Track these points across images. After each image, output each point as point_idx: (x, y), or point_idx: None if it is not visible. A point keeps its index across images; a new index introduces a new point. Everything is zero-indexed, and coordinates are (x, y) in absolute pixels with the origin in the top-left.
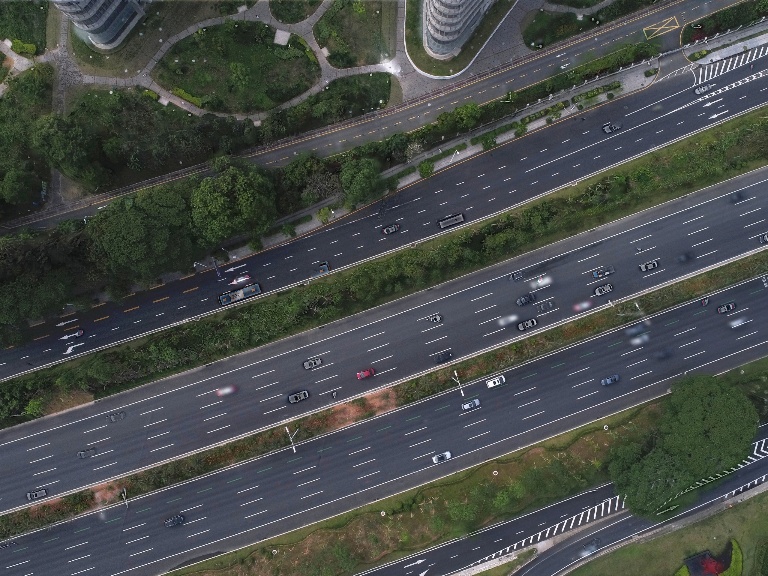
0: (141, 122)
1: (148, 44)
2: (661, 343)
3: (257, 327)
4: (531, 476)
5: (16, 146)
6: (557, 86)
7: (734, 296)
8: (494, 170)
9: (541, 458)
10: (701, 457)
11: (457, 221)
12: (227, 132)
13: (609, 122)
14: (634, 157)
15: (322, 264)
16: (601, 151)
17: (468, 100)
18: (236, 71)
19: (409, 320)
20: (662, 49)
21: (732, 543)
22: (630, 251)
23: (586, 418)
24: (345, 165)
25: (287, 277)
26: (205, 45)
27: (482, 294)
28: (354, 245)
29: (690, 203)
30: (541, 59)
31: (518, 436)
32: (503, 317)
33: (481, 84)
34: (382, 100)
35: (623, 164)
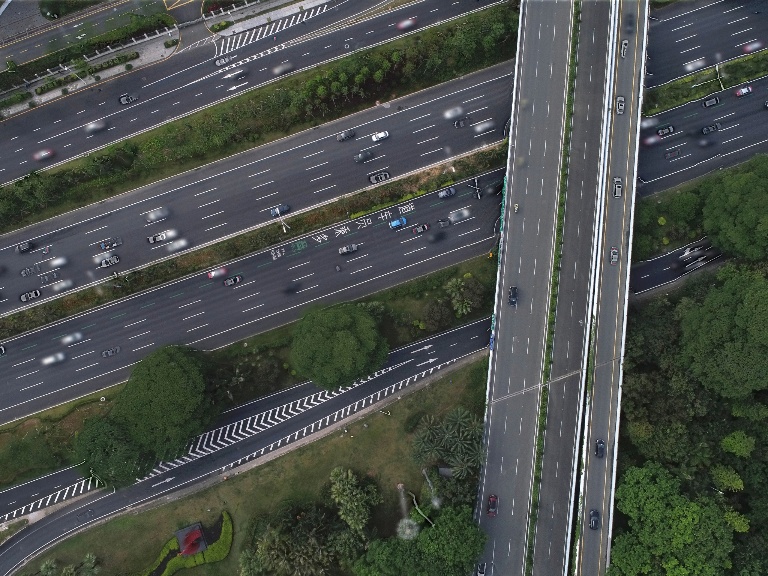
0: None
1: None
2: (165, 315)
3: None
4: (16, 446)
5: None
6: (69, 56)
7: (241, 269)
8: (6, 141)
9: (35, 429)
10: (146, 427)
11: None
12: None
13: (126, 93)
14: (149, 128)
15: None
16: (116, 122)
17: None
18: None
19: None
20: (182, 20)
21: (223, 515)
22: (139, 223)
23: (85, 390)
24: None
25: None
26: None
27: None
28: None
29: (203, 175)
30: (57, 29)
31: (15, 407)
32: (6, 288)
33: None
34: None
35: (137, 135)
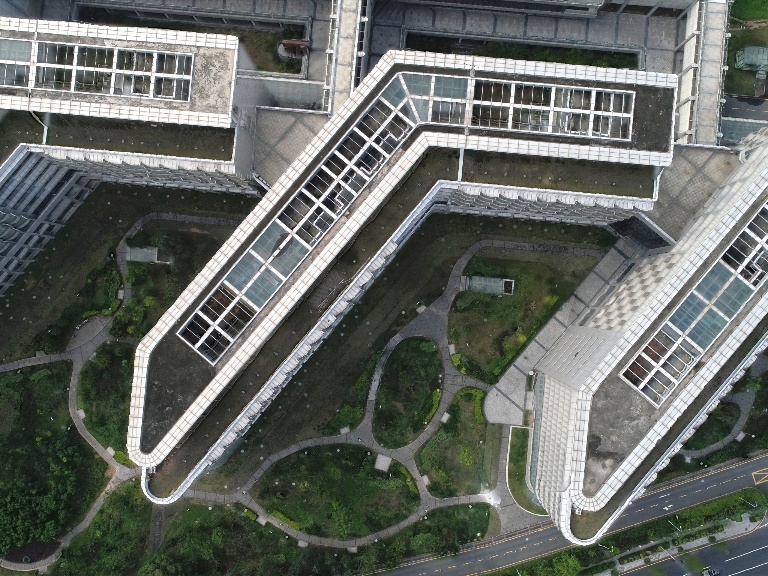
0: (239, 543)
1: (249, 461)
2: None
3: None
4: None
5: (117, 570)
6: (659, 531)
7: None
8: None
9: None
10: None
11: None
12: (325, 572)
13: (709, 566)
14: None
15: None
16: None
17: None
18: (339, 518)
19: None
20: None
21: None
22: None
23: None
24: None
25: None
26: (306, 469)
27: None
28: None
29: None
30: (644, 499)
31: None
32: None
33: None
34: (480, 533)
35: None
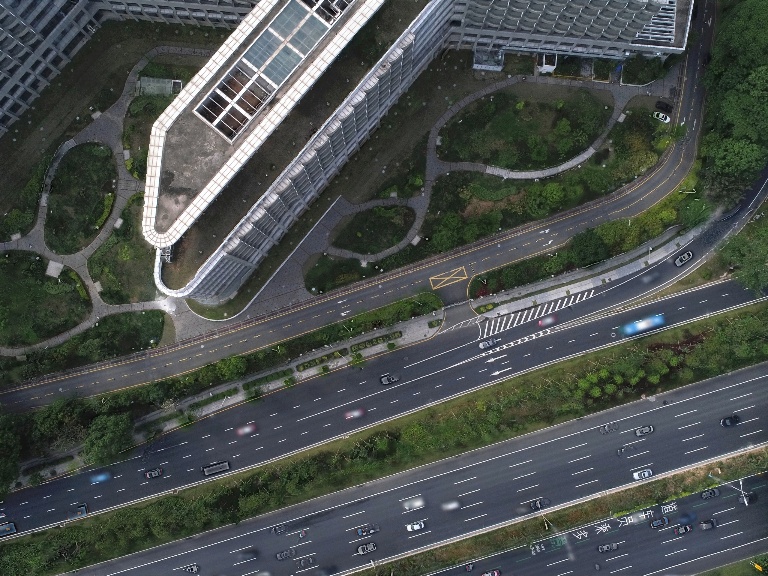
0: None
1: None
2: None
3: (7, 570)
4: None
5: None
6: (334, 336)
7: (500, 563)
8: (265, 417)
9: None
10: None
11: (222, 469)
12: None
13: (388, 373)
14: (410, 412)
15: (80, 506)
16: (376, 403)
17: (242, 344)
18: None
19: (165, 569)
20: (448, 300)
21: None
22: (397, 510)
23: None
24: (95, 421)
25: (44, 517)
26: None
27: (242, 546)
28: (114, 488)
29: (463, 463)
30: (321, 305)
31: None
32: (261, 571)
33: (257, 328)
34: (153, 340)
35: (398, 418)
